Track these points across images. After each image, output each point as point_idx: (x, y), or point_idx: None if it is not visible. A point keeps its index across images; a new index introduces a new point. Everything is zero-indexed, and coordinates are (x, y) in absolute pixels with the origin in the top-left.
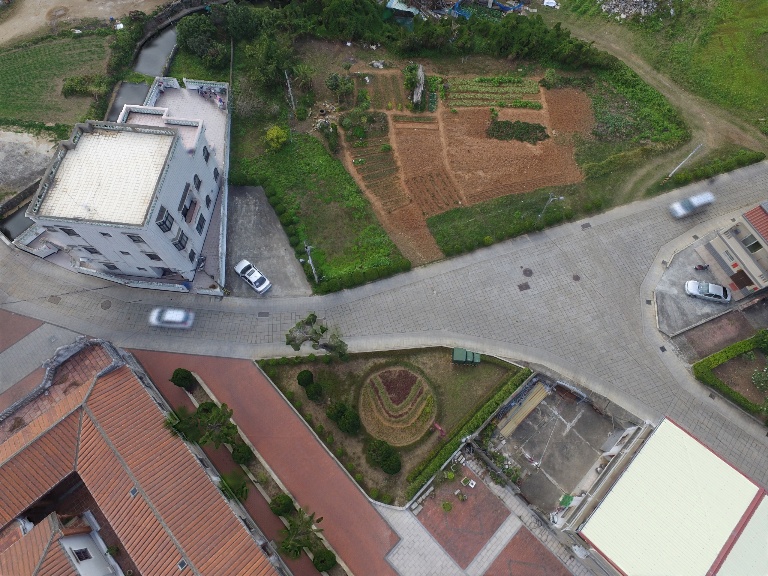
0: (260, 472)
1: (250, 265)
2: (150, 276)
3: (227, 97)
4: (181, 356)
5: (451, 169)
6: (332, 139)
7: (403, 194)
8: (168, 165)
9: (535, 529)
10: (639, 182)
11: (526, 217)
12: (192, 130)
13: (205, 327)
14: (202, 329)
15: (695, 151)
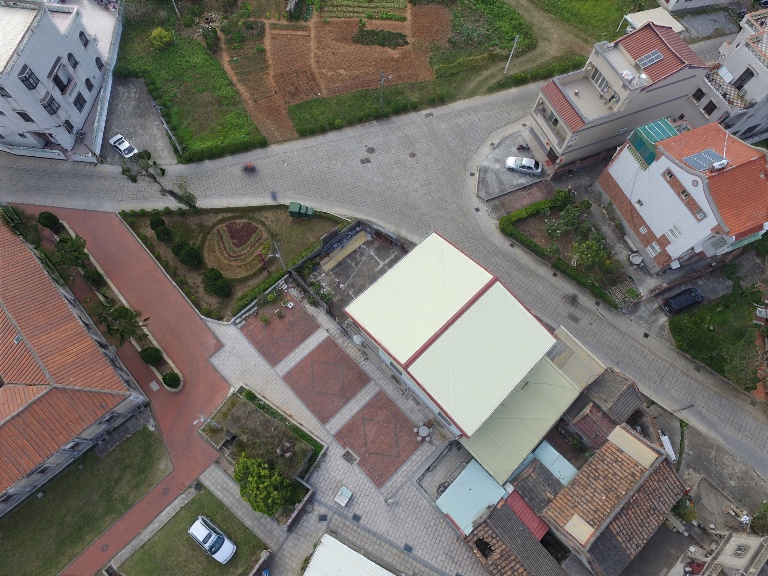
0: (110, 295)
1: (122, 138)
2: (33, 146)
3: (119, 3)
4: (54, 209)
5: (316, 67)
6: (209, 39)
7: (270, 87)
8: (32, 31)
9: (338, 338)
10: (482, 81)
11: (377, 107)
12: (69, 16)
13: (78, 187)
14: (75, 188)
15: (537, 57)
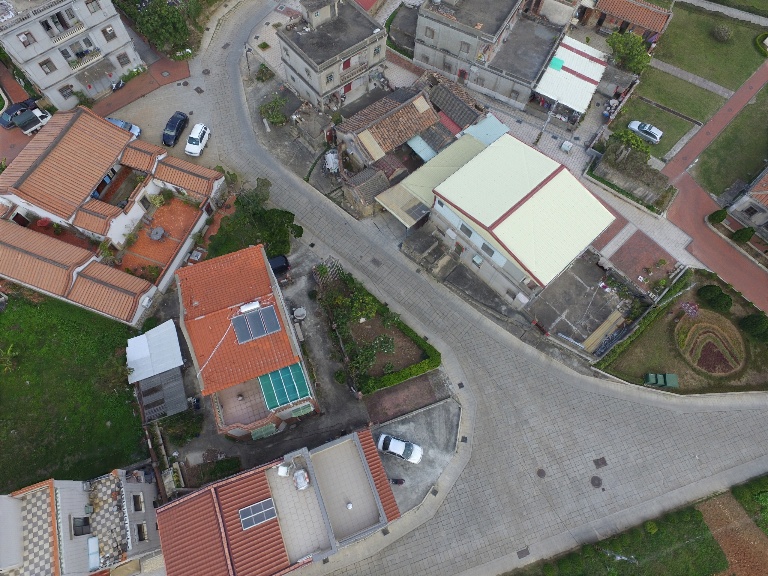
0: None
1: None
2: None
3: None
4: None
5: None
6: None
7: None
8: None
9: (591, 249)
10: None
11: (602, 569)
12: None
13: None
14: None
15: None
